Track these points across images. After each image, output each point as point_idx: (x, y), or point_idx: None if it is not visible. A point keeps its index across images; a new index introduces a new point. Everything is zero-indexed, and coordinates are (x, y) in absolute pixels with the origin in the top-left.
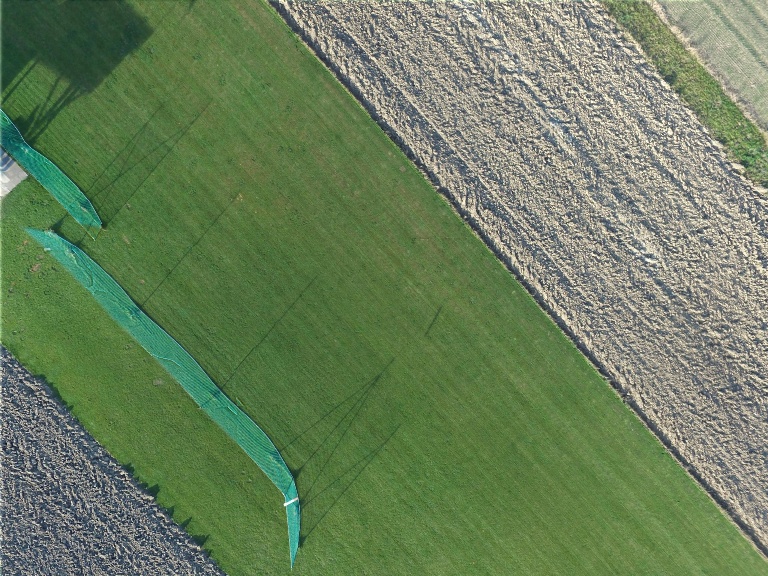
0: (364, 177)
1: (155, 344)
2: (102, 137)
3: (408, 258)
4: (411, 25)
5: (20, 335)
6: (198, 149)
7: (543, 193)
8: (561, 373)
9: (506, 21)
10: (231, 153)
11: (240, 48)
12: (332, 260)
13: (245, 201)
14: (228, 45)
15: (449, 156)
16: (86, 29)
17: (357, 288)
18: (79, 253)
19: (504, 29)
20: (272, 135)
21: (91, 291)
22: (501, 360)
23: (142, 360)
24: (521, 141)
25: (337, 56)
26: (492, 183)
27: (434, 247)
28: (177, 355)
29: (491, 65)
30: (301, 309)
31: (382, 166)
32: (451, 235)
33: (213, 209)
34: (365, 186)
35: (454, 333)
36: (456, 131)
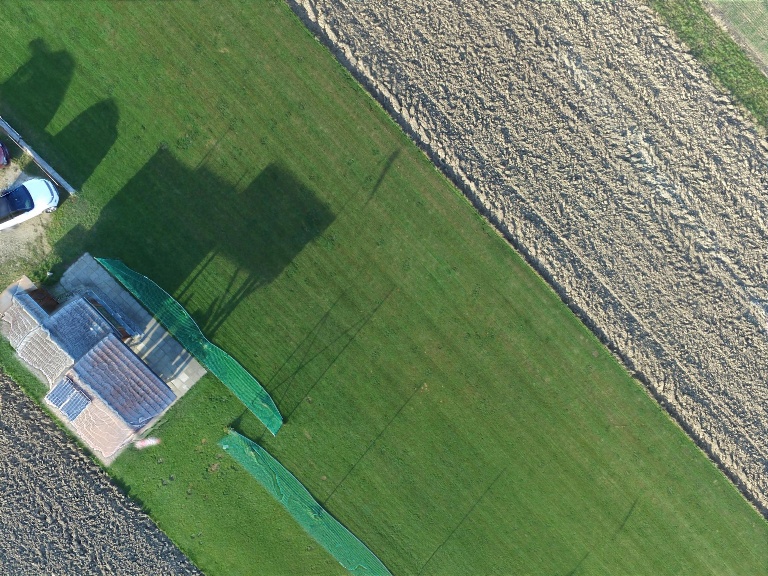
0: (556, 364)
1: (350, 557)
2: (282, 328)
3: (602, 447)
4: (602, 203)
5: (198, 538)
6: (381, 338)
7: (745, 376)
8: (767, 567)
9: (701, 196)
10: (416, 341)
11: (424, 232)
12: (522, 450)
13: (430, 390)
14: (412, 229)
15: (644, 339)
16: (267, 218)
17: (548, 479)
18: (260, 452)
19: (699, 205)
20: (459, 322)
21: (285, 505)
22: (703, 553)
23: (325, 561)
24: (720, 322)
25: (525, 237)
26: (690, 367)
27: (629, 435)
28: (364, 558)
29: (686, 242)
30: (490, 503)
31: (575, 352)
32: (647, 422)
33: (397, 399)
34: (556, 373)
35: (652, 525)
36: (651, 312)
